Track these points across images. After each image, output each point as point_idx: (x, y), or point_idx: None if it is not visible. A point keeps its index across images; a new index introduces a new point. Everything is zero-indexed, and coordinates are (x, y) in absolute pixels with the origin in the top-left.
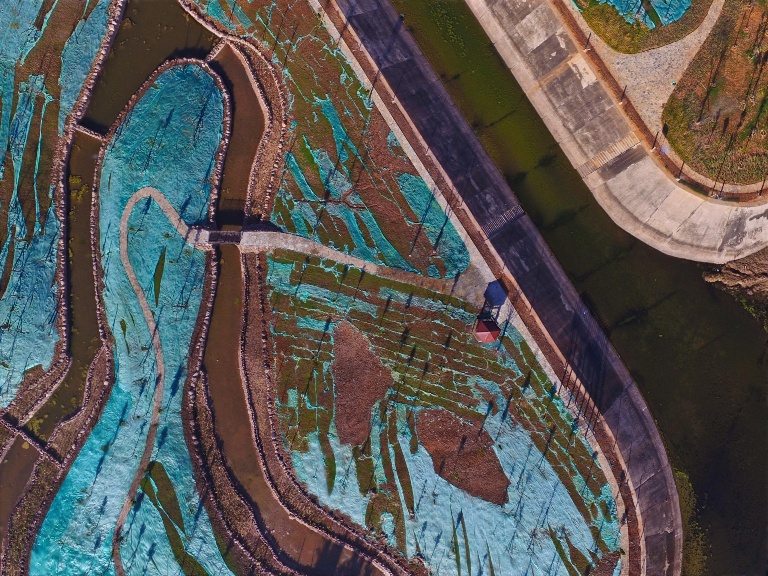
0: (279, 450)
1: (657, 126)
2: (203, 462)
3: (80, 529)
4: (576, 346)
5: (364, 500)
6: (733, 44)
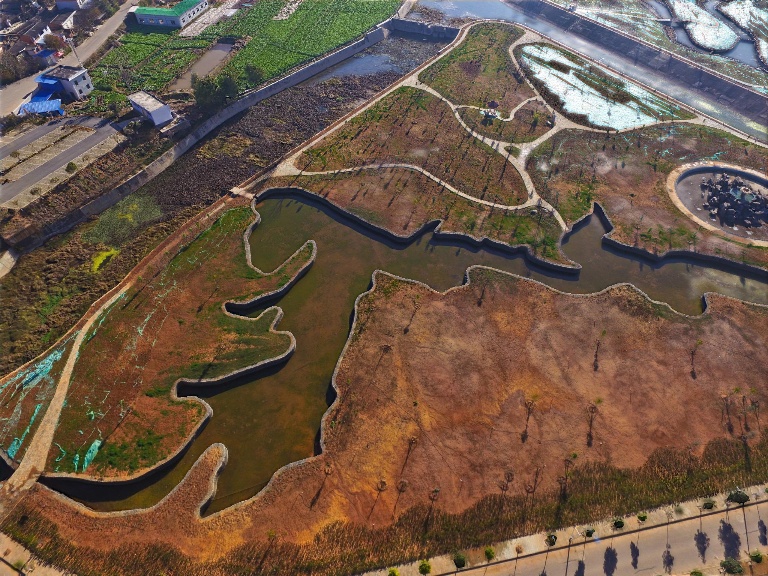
0: None
1: None
2: None
3: None
4: None
5: None
6: None
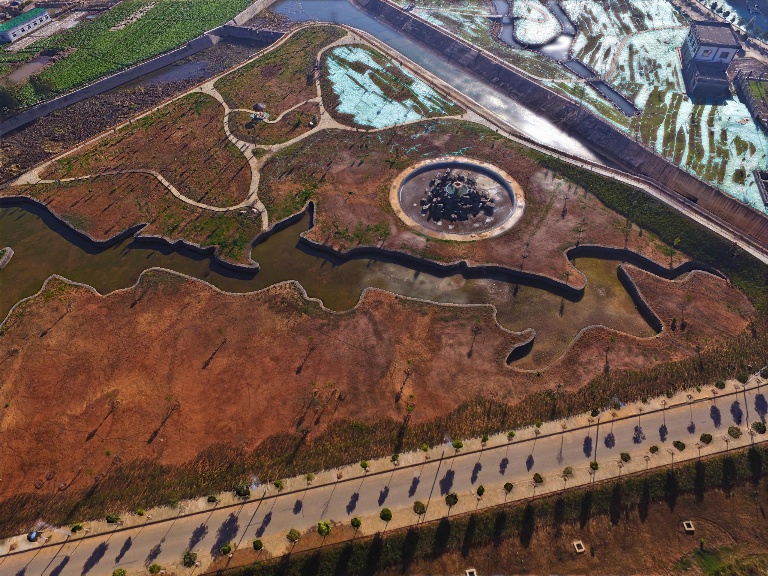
0: None
1: None
2: None
3: None
4: None
5: None
6: (319, 44)
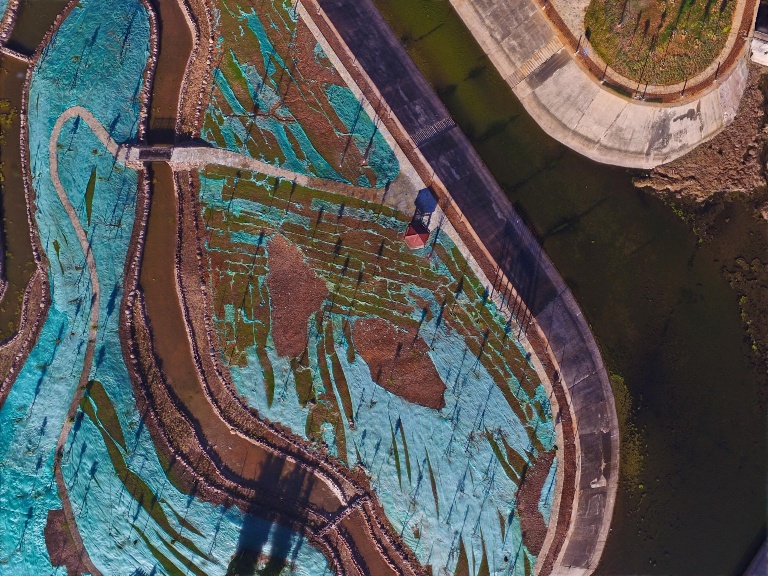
0: (218, 366)
1: (580, 30)
2: (142, 380)
3: (21, 451)
4: (508, 252)
5: (304, 411)
6: None
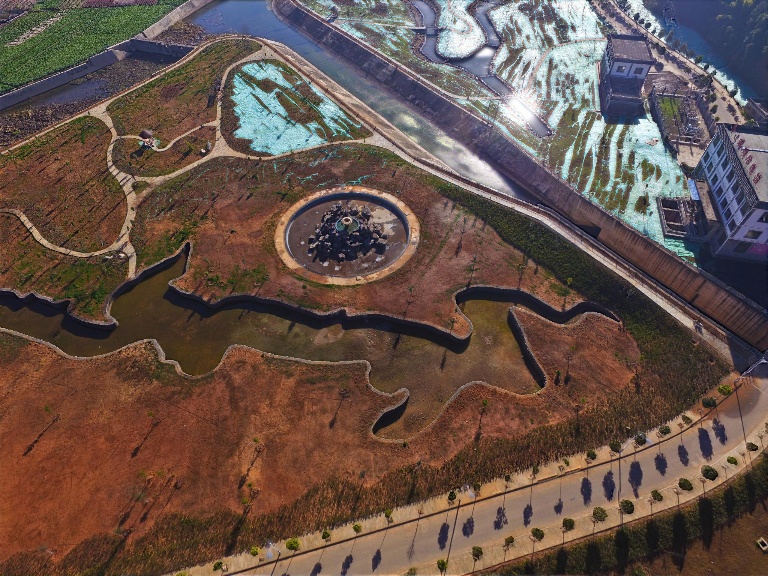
0: (406, 3)
1: None
2: None
3: None
4: None
5: None
6: (228, 60)
